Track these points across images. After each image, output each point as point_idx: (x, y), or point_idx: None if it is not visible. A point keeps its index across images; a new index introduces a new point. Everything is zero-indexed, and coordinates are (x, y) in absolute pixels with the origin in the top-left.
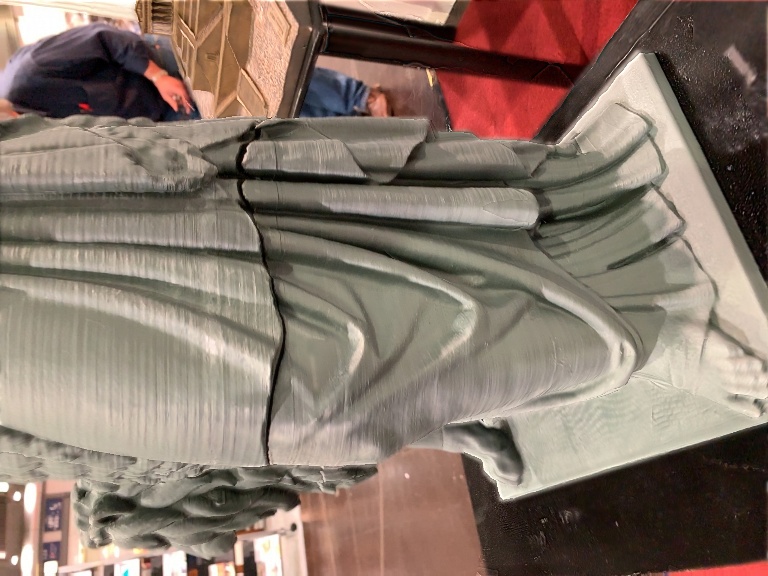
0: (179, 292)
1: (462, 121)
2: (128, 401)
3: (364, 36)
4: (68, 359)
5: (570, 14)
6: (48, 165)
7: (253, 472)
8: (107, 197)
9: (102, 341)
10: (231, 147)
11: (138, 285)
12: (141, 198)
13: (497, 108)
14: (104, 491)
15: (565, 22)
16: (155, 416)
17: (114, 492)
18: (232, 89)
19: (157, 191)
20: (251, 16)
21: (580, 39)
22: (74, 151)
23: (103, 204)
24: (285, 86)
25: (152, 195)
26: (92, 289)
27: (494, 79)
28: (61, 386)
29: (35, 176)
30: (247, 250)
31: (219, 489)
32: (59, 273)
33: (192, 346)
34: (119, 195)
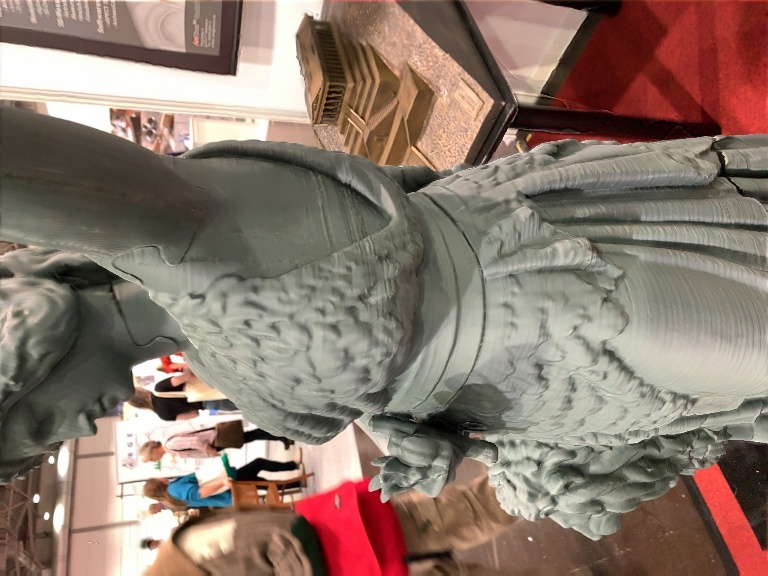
0: (730, 255)
1: None
2: (734, 332)
3: (532, 109)
4: (688, 302)
5: (684, 82)
6: (630, 166)
7: (673, 441)
8: (657, 190)
9: (704, 289)
10: (711, 154)
11: (700, 251)
12: (679, 190)
13: None
14: (566, 459)
15: (679, 89)
16: (752, 344)
17: (570, 460)
18: None
19: (688, 184)
20: (431, 99)
21: (699, 101)
22: (635, 157)
23: (658, 195)
24: (468, 155)
25: (685, 187)
26: (681, 253)
27: None
28: (686, 322)
29: (625, 174)
30: (761, 224)
31: (644, 458)
32: (651, 243)
33: (761, 291)
34: (664, 188)
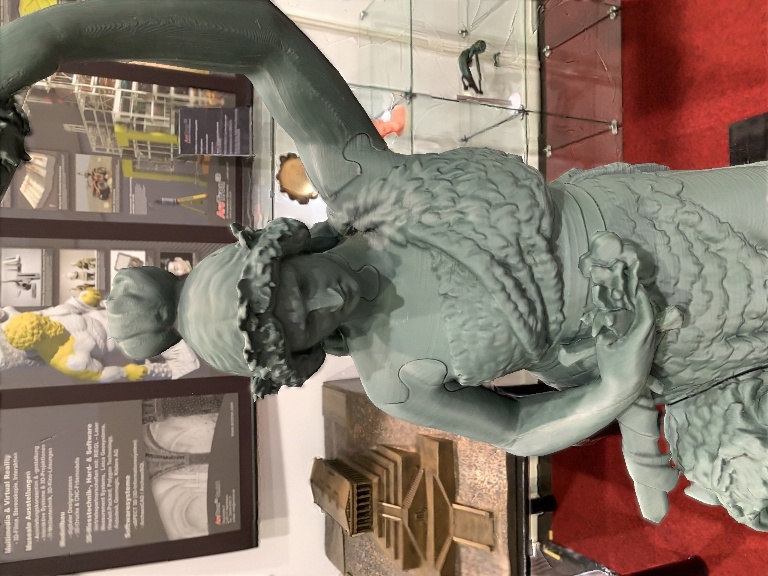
0: None
1: (613, 553)
2: None
3: None
4: (708, 171)
5: None
6: None
7: None
8: None
9: None
10: None
11: None
12: None
13: (638, 508)
14: (755, 383)
15: None
16: None
17: (762, 387)
18: (444, 538)
19: None
20: (452, 448)
21: None
22: None
23: None
24: (508, 471)
25: None
26: None
27: (617, 492)
28: (718, 175)
29: None
30: None
31: None
32: None
33: None
34: None
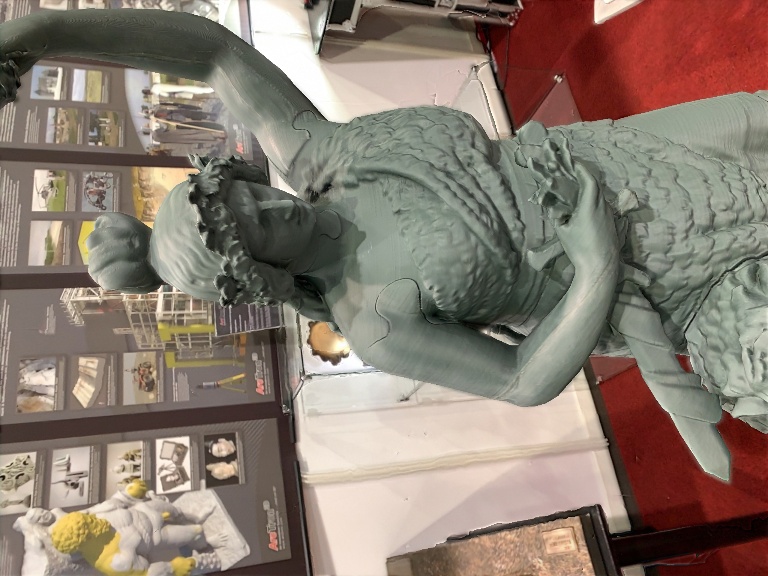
0: None
1: None
2: None
3: (627, 539)
4: None
5: (750, 511)
6: None
7: None
8: None
9: None
10: None
11: None
12: None
13: None
14: (750, 266)
15: None
16: None
17: (759, 269)
18: None
19: None
20: None
21: None
22: None
23: None
24: None
25: None
26: None
27: None
28: None
29: None
30: None
31: None
32: None
33: None
34: None
